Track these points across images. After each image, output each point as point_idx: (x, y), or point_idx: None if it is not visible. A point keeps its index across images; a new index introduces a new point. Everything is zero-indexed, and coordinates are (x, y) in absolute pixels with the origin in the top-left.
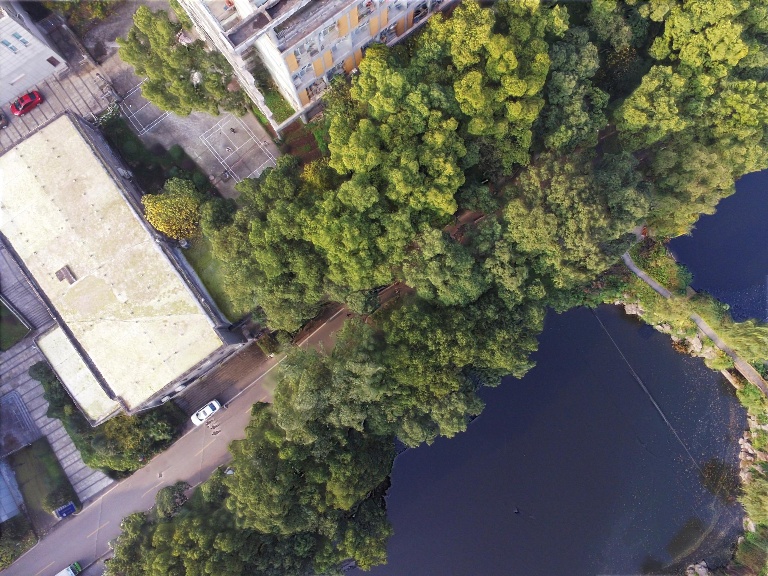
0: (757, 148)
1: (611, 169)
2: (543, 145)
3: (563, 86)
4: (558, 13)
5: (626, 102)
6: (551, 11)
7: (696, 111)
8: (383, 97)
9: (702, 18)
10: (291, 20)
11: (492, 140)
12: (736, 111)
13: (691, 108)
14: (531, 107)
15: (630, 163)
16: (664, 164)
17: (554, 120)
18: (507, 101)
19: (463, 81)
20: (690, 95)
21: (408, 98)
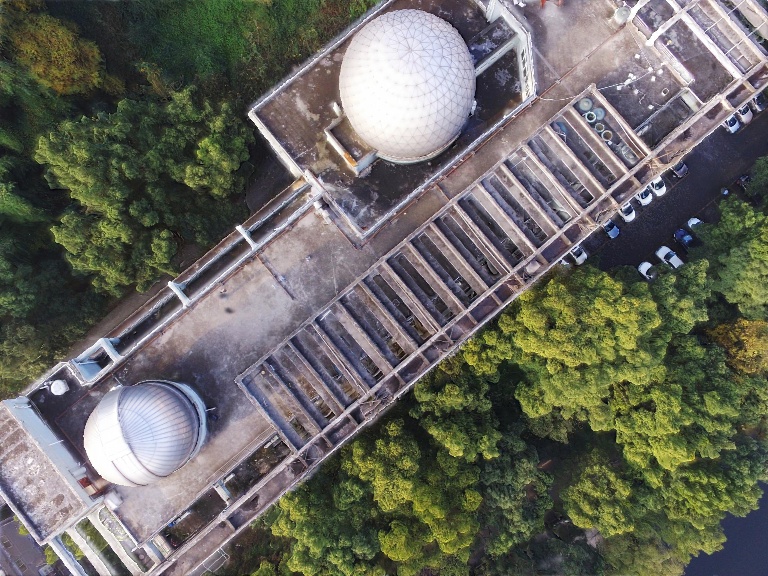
0: (713, 543)
1: (558, 567)
2: (483, 552)
3: (499, 504)
4: (487, 445)
5: (571, 489)
6: (480, 441)
7: (646, 503)
8: (301, 567)
9: (643, 430)
10: (192, 524)
11: (426, 566)
12: (688, 501)
13: (640, 500)
14: (464, 542)
15: (577, 570)
16: (615, 553)
17: (494, 520)
18: (438, 538)
19: (386, 542)
20: (639, 479)
21: (329, 559)
